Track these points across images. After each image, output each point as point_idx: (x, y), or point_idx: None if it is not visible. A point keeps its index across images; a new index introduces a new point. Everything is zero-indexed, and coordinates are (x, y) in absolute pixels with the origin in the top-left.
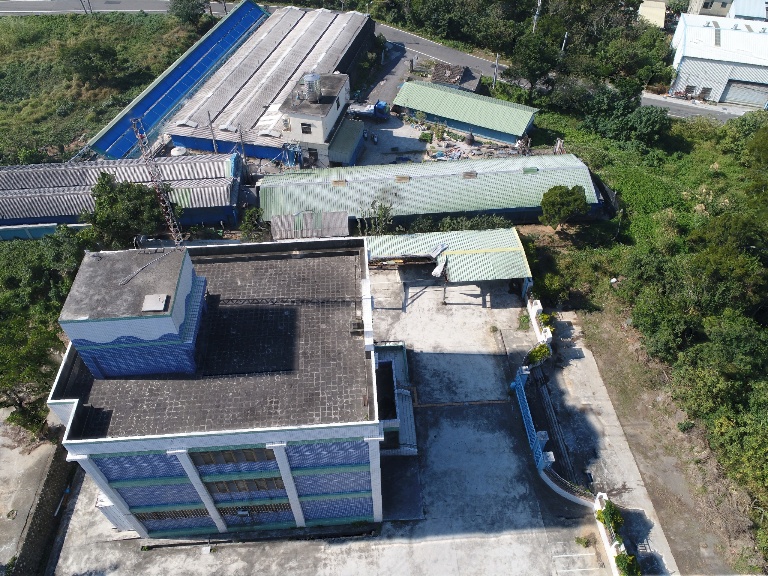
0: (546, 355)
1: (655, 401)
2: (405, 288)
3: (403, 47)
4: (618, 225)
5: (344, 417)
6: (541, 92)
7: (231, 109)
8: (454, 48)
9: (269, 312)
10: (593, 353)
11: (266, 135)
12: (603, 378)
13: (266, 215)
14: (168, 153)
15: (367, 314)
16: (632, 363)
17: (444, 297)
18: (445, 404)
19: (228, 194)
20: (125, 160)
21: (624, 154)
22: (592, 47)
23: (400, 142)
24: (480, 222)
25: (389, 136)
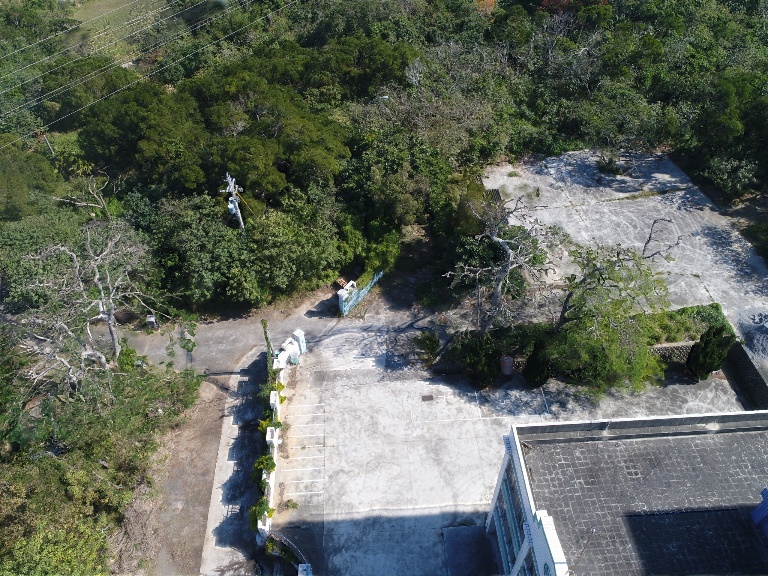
0: None
1: None
2: None
3: None
4: None
5: (549, 456)
6: None
7: None
8: None
9: None
10: None
11: None
12: None
13: None
14: None
15: (554, 541)
16: None
17: None
18: None
19: None
20: None
21: None
22: None
23: None
24: None
25: None
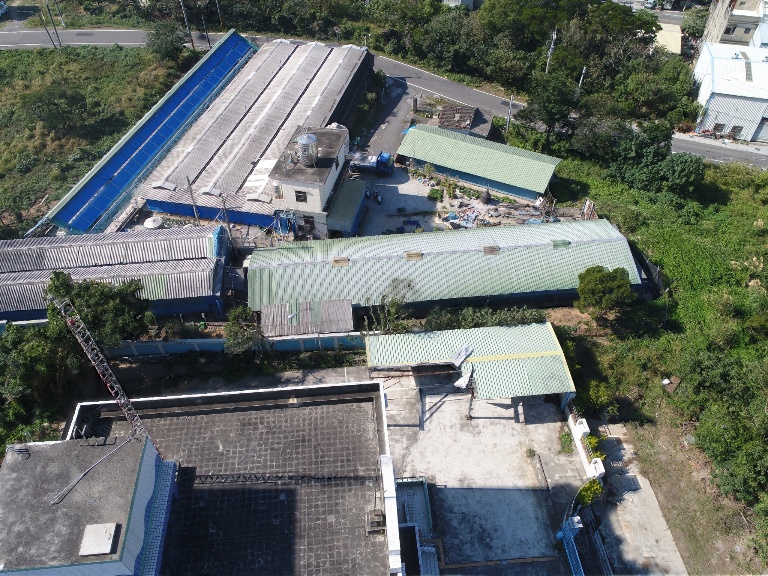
0: (598, 494)
1: (733, 552)
2: (422, 396)
3: (404, 82)
4: (664, 308)
5: None
6: (560, 136)
7: (214, 166)
8: (460, 82)
9: (260, 496)
10: (651, 482)
11: (255, 199)
12: (666, 518)
13: (255, 303)
14: (142, 219)
15: (391, 522)
16: (699, 496)
17: (469, 412)
18: (478, 564)
19: (210, 281)
20: (90, 236)
21: (657, 209)
22: (610, 81)
23: (407, 201)
24: (509, 317)
25: (394, 193)
